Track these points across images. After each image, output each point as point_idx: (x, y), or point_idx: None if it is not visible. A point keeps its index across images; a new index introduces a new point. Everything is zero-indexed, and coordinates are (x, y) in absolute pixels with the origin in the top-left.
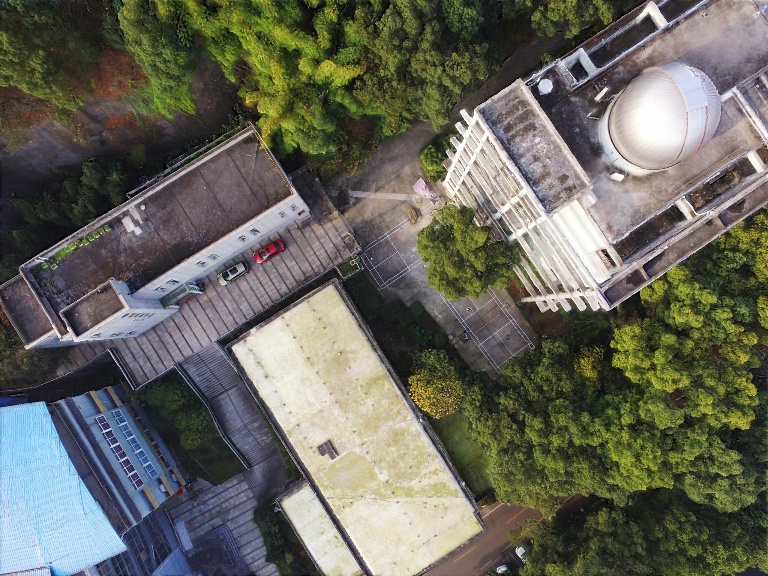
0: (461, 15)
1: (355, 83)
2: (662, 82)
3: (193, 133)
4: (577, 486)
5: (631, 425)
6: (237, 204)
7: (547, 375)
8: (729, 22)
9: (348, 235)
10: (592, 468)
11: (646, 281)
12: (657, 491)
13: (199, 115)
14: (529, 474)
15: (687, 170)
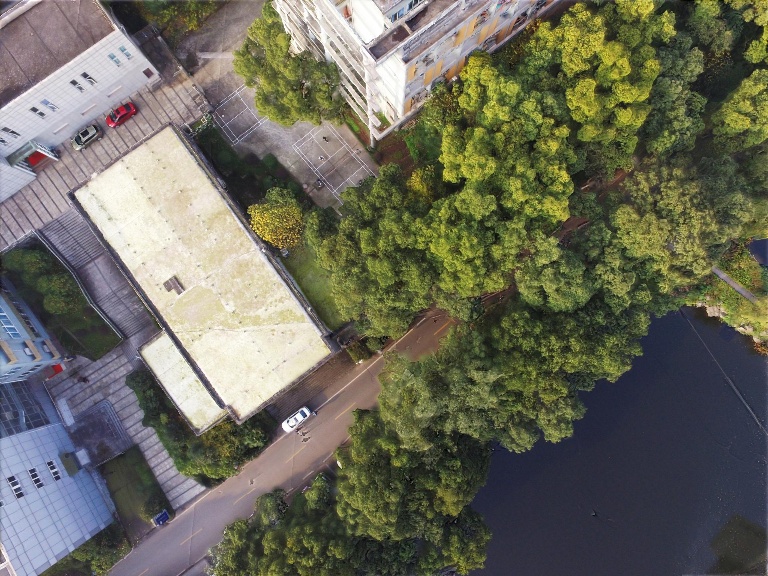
0: None
1: None
2: None
3: None
4: (416, 298)
5: (451, 221)
6: (64, 47)
7: (378, 191)
8: None
9: (198, 94)
10: (421, 271)
11: (409, 35)
12: (504, 307)
13: None
14: (365, 287)
15: None
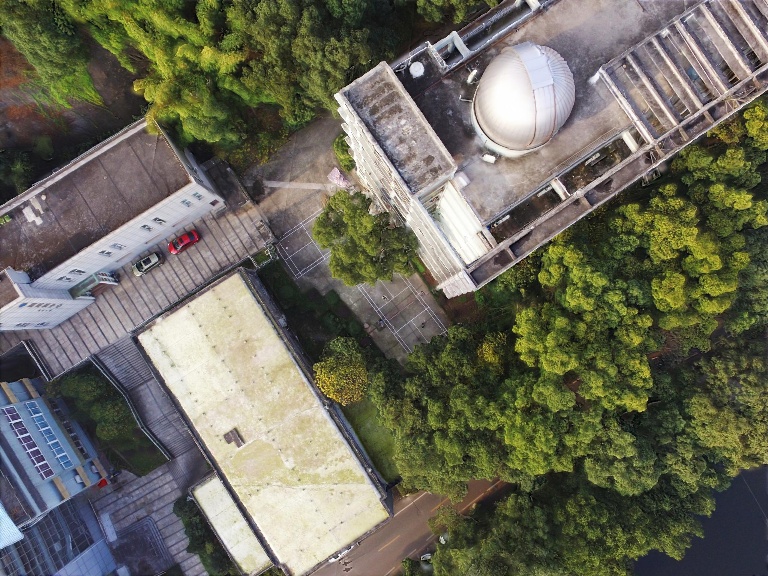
0: (340, 0)
1: (242, 70)
2: (511, 61)
3: (105, 125)
4: (480, 471)
5: (526, 408)
6: (138, 193)
7: (449, 360)
8: (601, 3)
9: (263, 225)
10: (490, 452)
11: (512, 261)
12: (566, 476)
13: (108, 106)
14: (431, 459)
15: (560, 151)
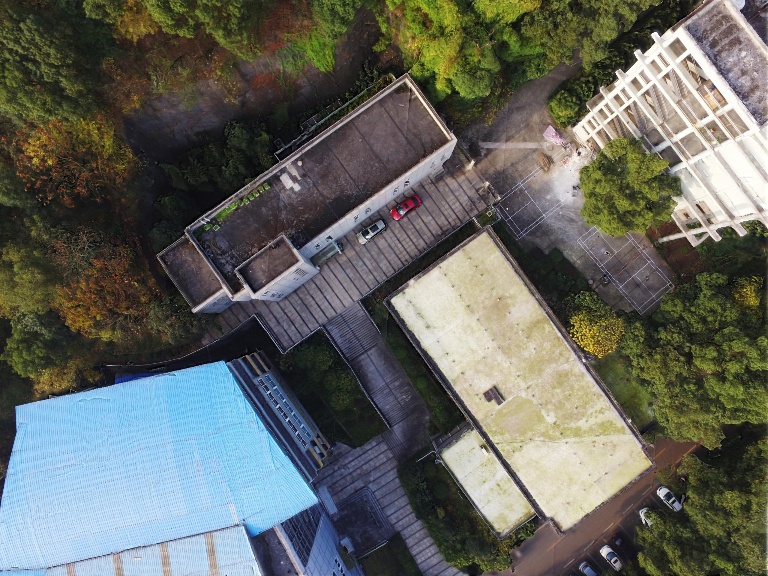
0: None
1: (523, 19)
2: None
3: (324, 93)
4: (746, 414)
5: None
6: (394, 154)
7: (711, 305)
8: None
9: (482, 187)
10: (767, 392)
11: None
12: None
13: (334, 72)
14: (701, 404)
15: None
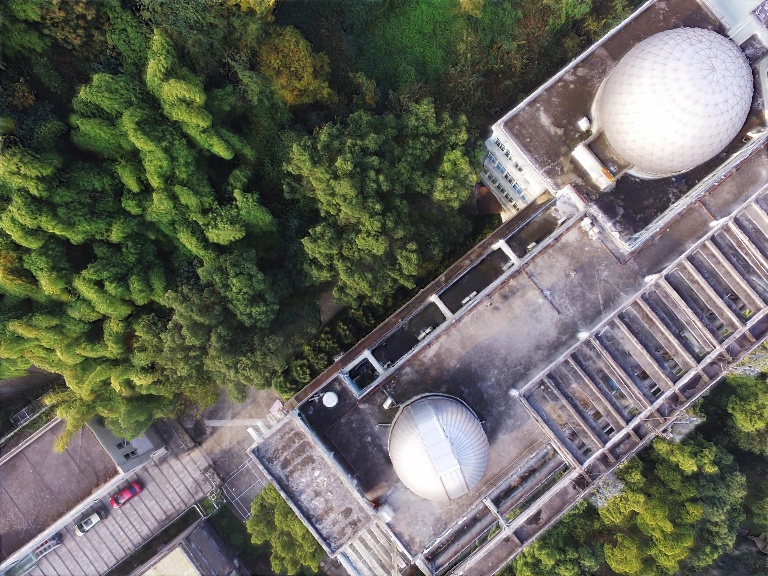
0: (250, 313)
1: None
2: (415, 441)
3: (36, 383)
4: None
5: None
6: (66, 485)
7: None
8: (515, 310)
9: None
10: None
11: None
12: None
13: (35, 372)
14: None
15: (486, 470)
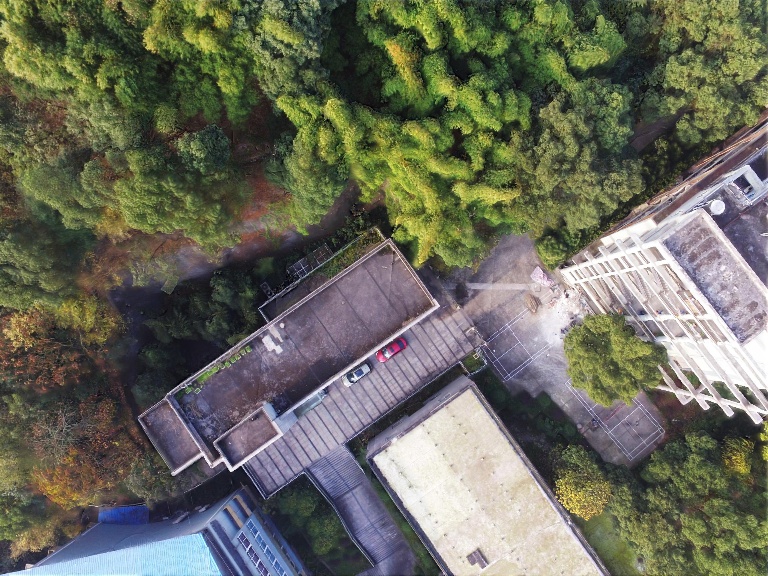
0: (616, 133)
1: (504, 200)
2: None
3: (311, 236)
4: None
5: None
6: (376, 317)
7: (700, 473)
8: None
9: (469, 328)
10: (759, 571)
11: None
12: None
13: (321, 221)
14: None
15: None
